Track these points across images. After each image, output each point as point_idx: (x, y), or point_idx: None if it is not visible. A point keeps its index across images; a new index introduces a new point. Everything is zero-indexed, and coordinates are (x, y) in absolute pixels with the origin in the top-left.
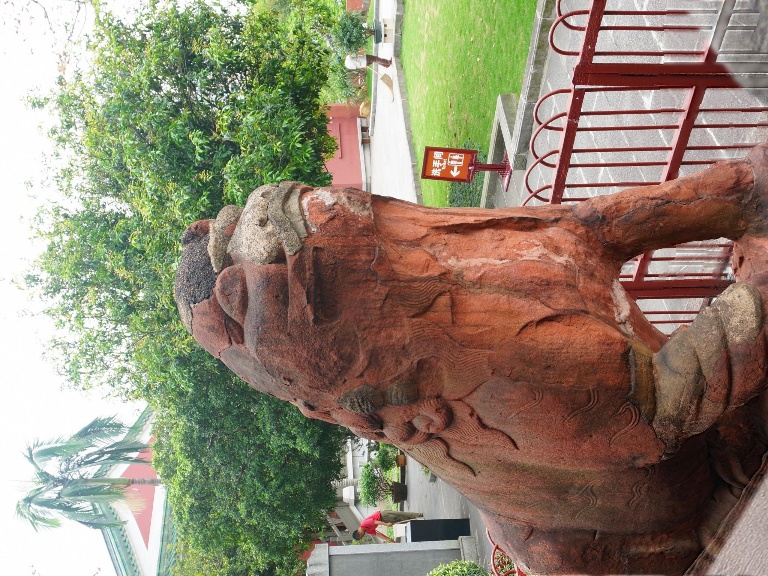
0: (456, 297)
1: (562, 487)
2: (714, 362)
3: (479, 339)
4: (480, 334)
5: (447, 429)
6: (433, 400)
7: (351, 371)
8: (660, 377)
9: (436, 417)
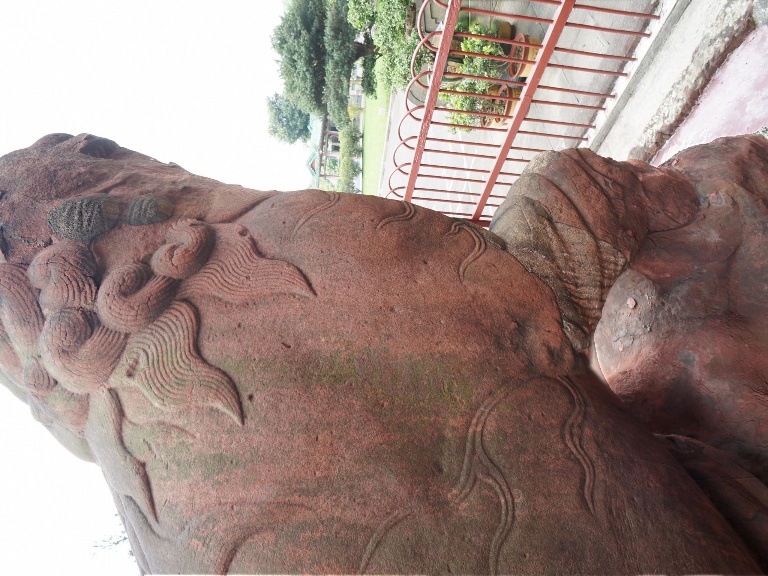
0: None
1: (423, 446)
2: (536, 184)
3: None
4: None
5: (202, 269)
6: (191, 219)
7: (94, 188)
8: None
9: (188, 233)
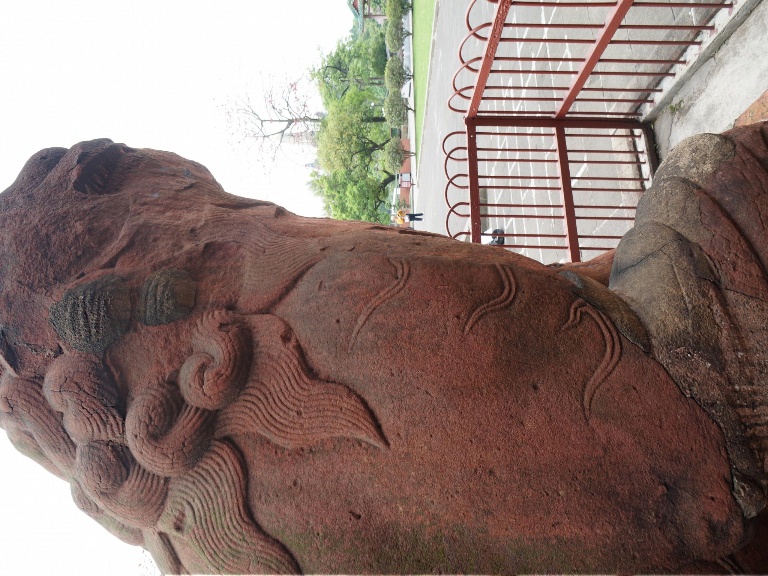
0: (290, 214)
1: None
2: (695, 211)
3: (310, 231)
4: (313, 227)
5: (242, 395)
6: (219, 311)
7: (98, 258)
8: (624, 289)
9: (218, 342)
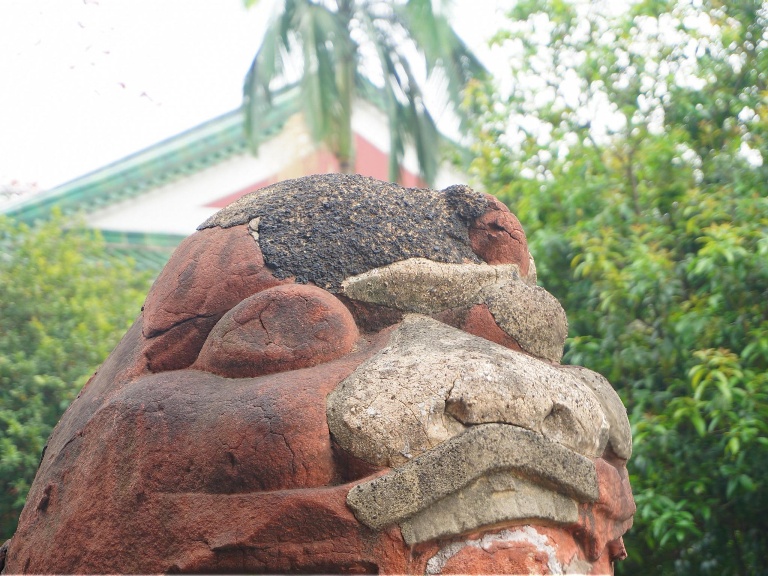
0: None
1: None
2: None
3: None
4: None
5: None
6: None
7: None
8: None
9: None
